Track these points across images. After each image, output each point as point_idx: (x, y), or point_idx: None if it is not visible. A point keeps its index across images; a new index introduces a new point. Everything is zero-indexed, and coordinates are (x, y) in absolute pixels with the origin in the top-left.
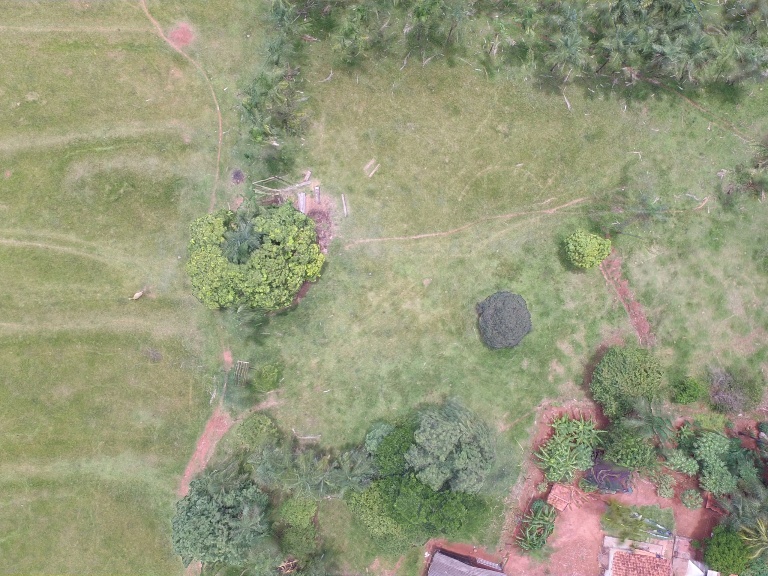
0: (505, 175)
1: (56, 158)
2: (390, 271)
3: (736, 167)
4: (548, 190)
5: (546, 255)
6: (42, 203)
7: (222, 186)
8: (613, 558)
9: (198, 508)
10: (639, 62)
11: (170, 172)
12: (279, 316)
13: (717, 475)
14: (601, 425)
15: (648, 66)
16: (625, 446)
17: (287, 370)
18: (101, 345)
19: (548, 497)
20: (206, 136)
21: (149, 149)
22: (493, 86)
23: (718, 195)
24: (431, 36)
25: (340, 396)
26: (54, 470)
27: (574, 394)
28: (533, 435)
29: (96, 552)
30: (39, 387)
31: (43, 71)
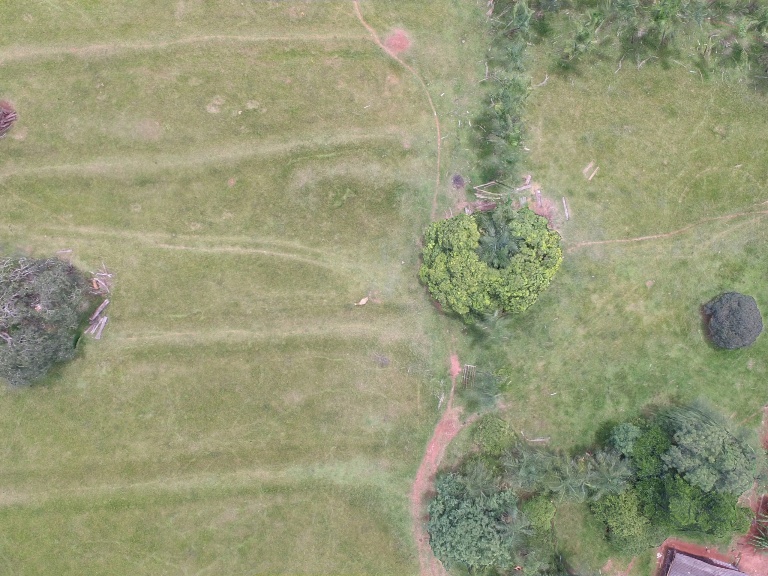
0: (724, 176)
1: (278, 166)
2: (613, 273)
3: None
4: (767, 191)
5: None
6: (266, 210)
7: (443, 191)
8: None
9: (459, 512)
10: None
11: (391, 178)
12: (505, 320)
13: None
14: None
15: None
16: None
17: (514, 373)
18: (329, 351)
19: None
20: (426, 142)
21: (370, 155)
22: (708, 88)
23: None
24: (645, 39)
25: (567, 398)
26: (288, 475)
27: None
28: (761, 435)
29: (332, 556)
30: (270, 393)
31: (262, 79)
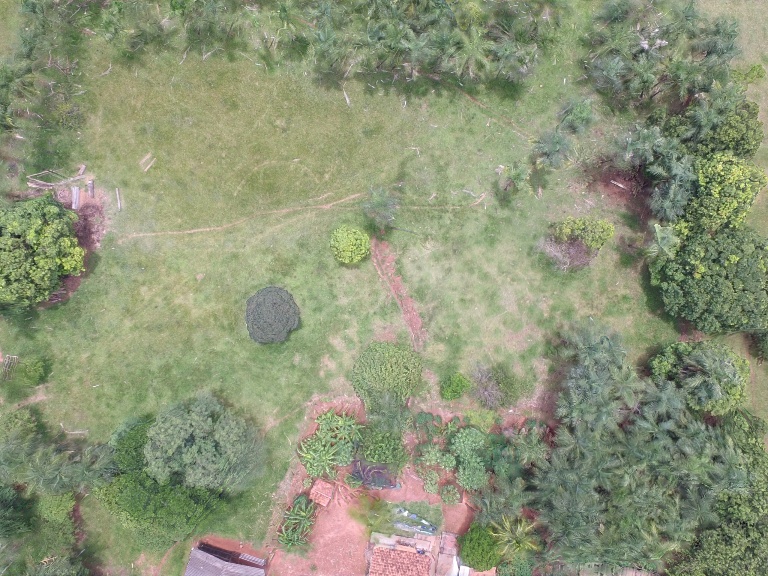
0: (282, 170)
1: None
2: (163, 266)
3: (514, 163)
4: (324, 185)
5: (320, 250)
6: None
7: None
8: (372, 554)
9: None
10: (420, 58)
11: None
12: (49, 310)
13: (470, 471)
14: (361, 420)
15: (428, 62)
16: (374, 441)
17: (56, 364)
18: None
19: (310, 492)
20: None
21: None
22: (272, 81)
23: (495, 191)
24: (212, 30)
25: (110, 391)
26: None
27: (345, 390)
28: (303, 430)
29: None
30: None
31: None
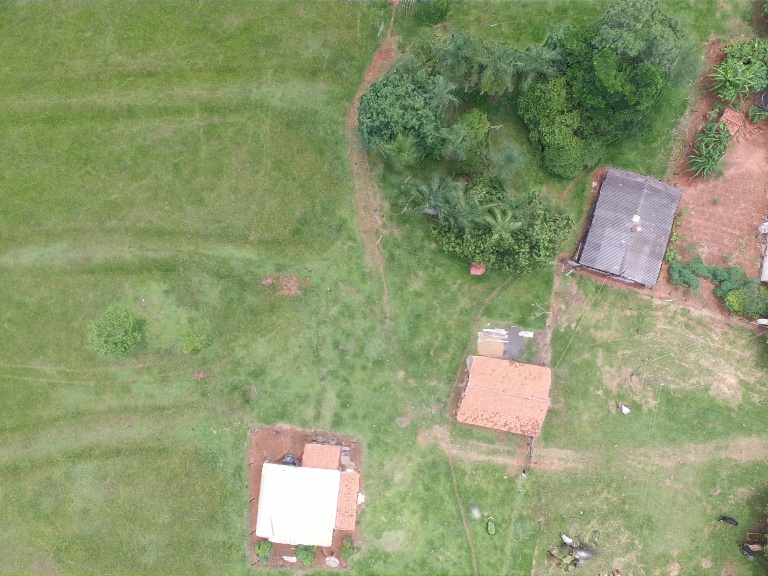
0: None
1: None
2: None
3: None
4: None
5: None
6: None
7: None
8: None
9: None
10: None
11: None
12: None
13: None
14: None
15: None
16: None
17: (455, 4)
18: None
19: (720, 120)
20: None
21: None
22: None
23: None
24: None
25: (507, 30)
26: (225, 95)
27: (742, 30)
28: (701, 69)
29: (267, 174)
30: (210, 16)
31: None
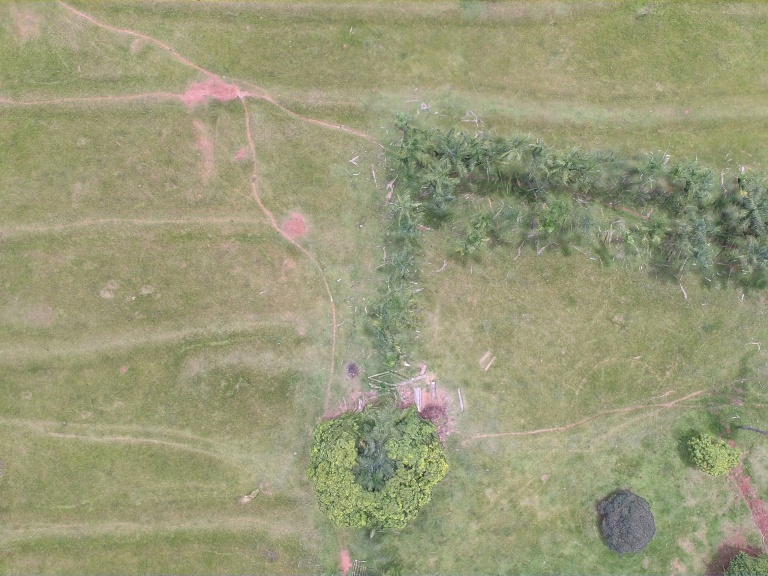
0: (622, 368)
1: (171, 353)
2: (508, 467)
3: None
4: (666, 383)
5: (666, 451)
6: (158, 399)
7: (337, 380)
8: None
9: None
10: None
11: (285, 366)
12: None
13: None
14: None
15: None
16: None
17: (405, 569)
18: (218, 544)
19: None
20: (321, 329)
21: (264, 343)
22: (608, 276)
23: None
24: None
25: None
26: None
27: None
28: None
29: None
30: None
31: (157, 264)
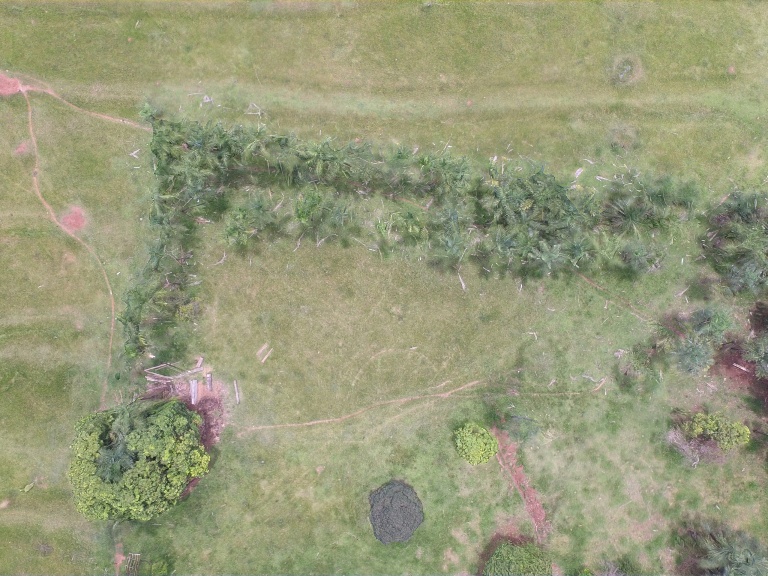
0: (399, 358)
1: None
2: (283, 459)
3: (633, 347)
4: (442, 373)
5: (440, 441)
6: None
7: (114, 373)
8: None
9: None
10: None
11: (62, 360)
12: None
13: None
14: None
15: None
16: None
17: (179, 562)
18: None
19: None
20: (98, 323)
21: (41, 337)
22: (387, 267)
23: (615, 376)
24: (325, 216)
25: None
26: None
27: None
28: None
29: None
30: None
31: None
